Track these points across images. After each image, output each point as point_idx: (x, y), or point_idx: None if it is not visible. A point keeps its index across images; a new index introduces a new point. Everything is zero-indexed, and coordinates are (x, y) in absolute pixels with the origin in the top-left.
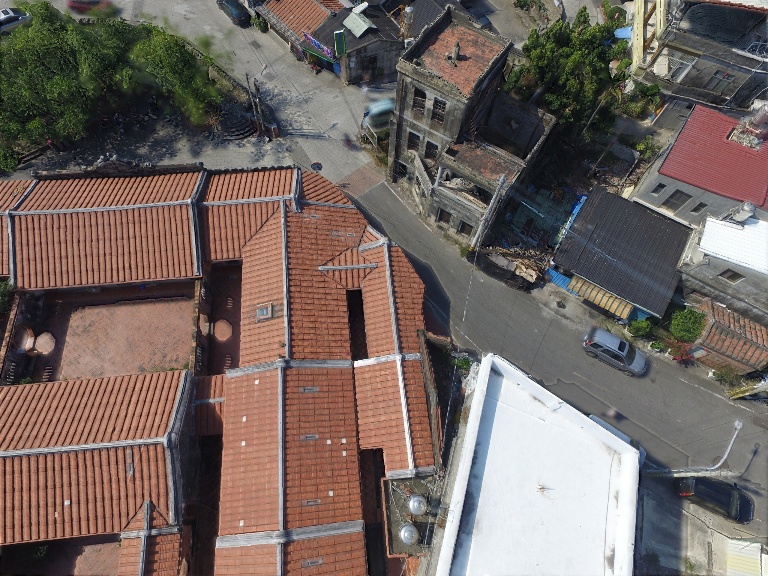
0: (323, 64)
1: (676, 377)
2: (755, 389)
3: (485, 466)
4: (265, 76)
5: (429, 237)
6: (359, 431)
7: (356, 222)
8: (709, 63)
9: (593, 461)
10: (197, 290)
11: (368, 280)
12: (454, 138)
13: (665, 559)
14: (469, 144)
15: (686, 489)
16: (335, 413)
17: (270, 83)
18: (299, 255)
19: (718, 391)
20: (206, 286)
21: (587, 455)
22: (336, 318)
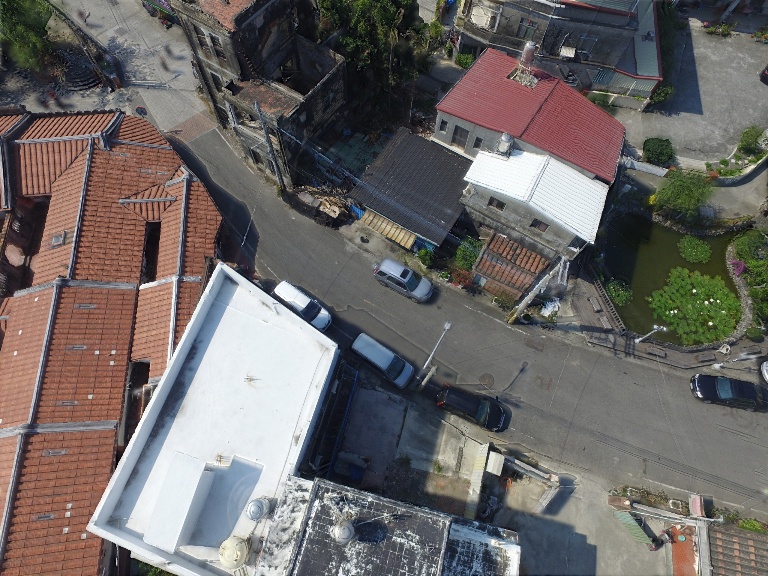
0: (174, 19)
1: (462, 304)
2: (517, 310)
3: (202, 360)
4: (117, 31)
5: (250, 179)
6: (133, 345)
7: (170, 162)
8: (513, 10)
9: (304, 356)
10: (6, 222)
11: (167, 212)
12: (238, 75)
13: (416, 462)
14: (255, 81)
15: (440, 399)
16: (109, 328)
17: (121, 37)
18: (100, 188)
19: (499, 316)
20: (23, 221)
21: (300, 351)
22: (130, 246)
